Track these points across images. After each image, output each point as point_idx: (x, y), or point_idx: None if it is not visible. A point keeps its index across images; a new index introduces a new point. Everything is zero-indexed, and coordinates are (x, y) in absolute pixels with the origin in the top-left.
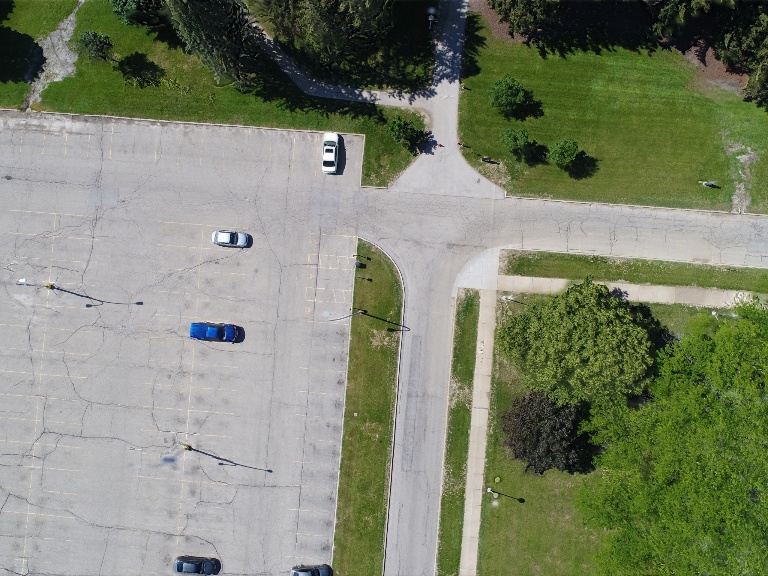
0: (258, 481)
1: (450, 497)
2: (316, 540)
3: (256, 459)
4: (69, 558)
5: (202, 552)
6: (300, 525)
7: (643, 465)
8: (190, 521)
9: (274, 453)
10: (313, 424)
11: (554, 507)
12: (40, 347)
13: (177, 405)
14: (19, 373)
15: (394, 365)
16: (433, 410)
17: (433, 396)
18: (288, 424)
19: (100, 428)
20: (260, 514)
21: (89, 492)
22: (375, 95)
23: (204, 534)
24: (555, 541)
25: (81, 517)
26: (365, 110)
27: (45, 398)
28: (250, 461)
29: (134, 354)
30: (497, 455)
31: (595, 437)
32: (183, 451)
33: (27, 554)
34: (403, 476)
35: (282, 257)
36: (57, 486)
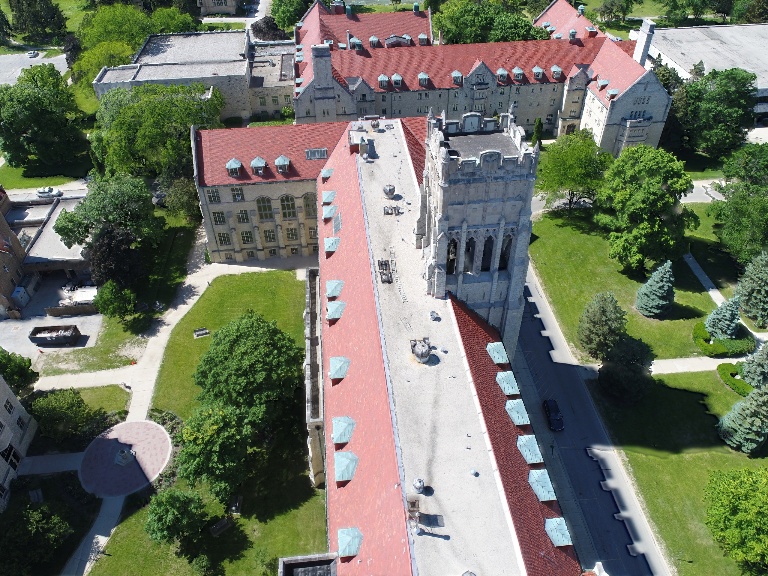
0: None
1: None
2: None
3: None
4: None
5: None
6: None
7: None
8: None
9: None
10: None
11: None
12: None
13: None
14: None
15: None
16: None
17: None
18: None
19: None
20: None
21: None
22: (55, 47)
23: None
24: (88, 103)
25: None
26: (50, 49)
27: None
28: None
29: None
30: None
31: None
32: None
33: None
34: None
35: (3, 70)
36: None
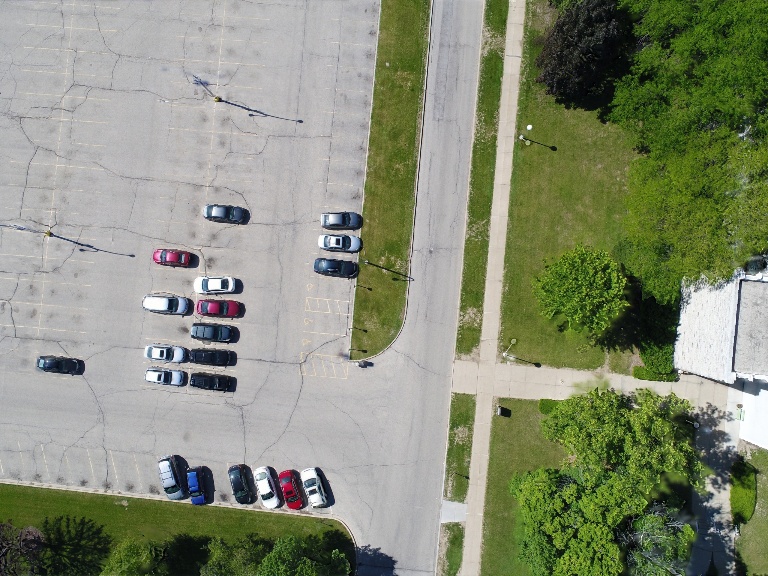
0: (288, 132)
1: (482, 144)
2: (346, 189)
3: (287, 110)
4: (97, 210)
5: (231, 202)
6: (330, 175)
7: (686, 7)
8: (220, 172)
9: (305, 104)
10: (344, 75)
11: (586, 156)
12: (71, 1)
13: (208, 57)
14: (49, 27)
15: (426, 14)
16: (465, 59)
17: (465, 45)
18: (319, 75)
19: (130, 81)
20: (290, 164)
21: (118, 144)
22: None
23: (234, 185)
24: (587, 190)
25: (110, 169)
26: None
27: (75, 52)
28: (281, 112)
29: (165, 7)
30: (529, 103)
31: (635, 6)
32: (213, 102)
33: (55, 206)
34: (434, 125)
35: None
36: (86, 138)
